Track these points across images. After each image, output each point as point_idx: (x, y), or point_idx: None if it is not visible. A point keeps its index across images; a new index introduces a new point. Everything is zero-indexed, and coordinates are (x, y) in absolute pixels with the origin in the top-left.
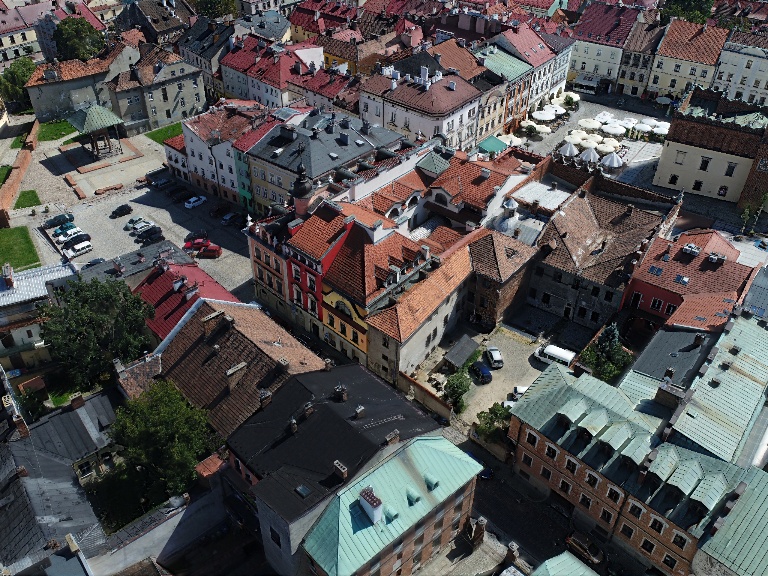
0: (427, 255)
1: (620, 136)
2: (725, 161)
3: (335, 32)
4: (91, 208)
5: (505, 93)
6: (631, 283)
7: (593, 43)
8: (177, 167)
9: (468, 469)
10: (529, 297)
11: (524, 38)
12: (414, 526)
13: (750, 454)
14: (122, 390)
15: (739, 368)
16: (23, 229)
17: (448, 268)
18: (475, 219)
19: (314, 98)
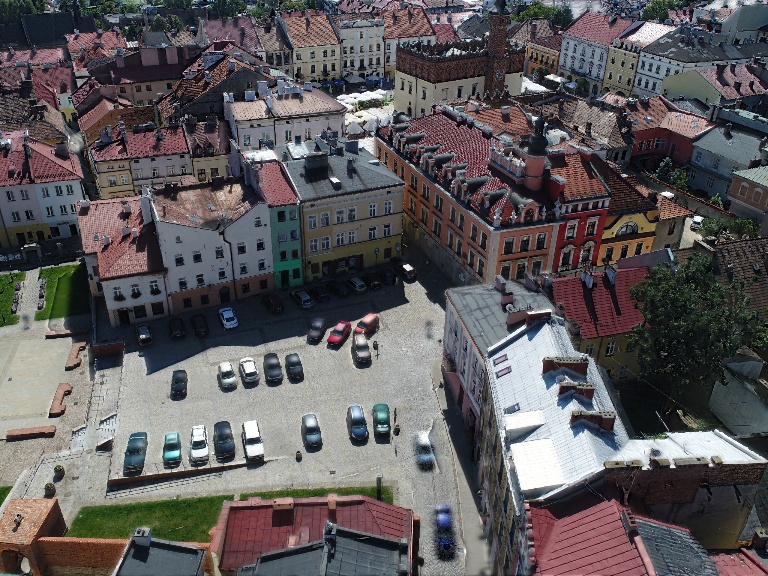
0: None
1: (348, 112)
2: (471, 85)
3: None
4: (125, 416)
5: None
6: None
7: None
8: (136, 305)
9: None
10: None
11: None
12: None
13: None
14: (736, 365)
15: None
16: (93, 512)
17: None
18: None
19: (153, 165)
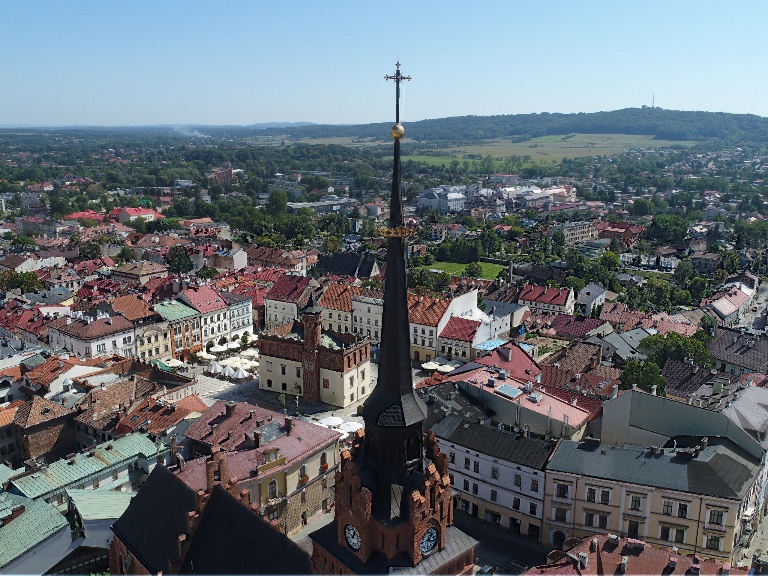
0: None
1: None
2: (294, 366)
3: (96, 299)
4: None
5: (167, 329)
6: (118, 427)
7: (278, 301)
8: None
9: None
10: (78, 450)
11: (203, 295)
12: None
13: None
14: None
15: (102, 456)
16: None
17: None
18: (43, 394)
19: (29, 336)
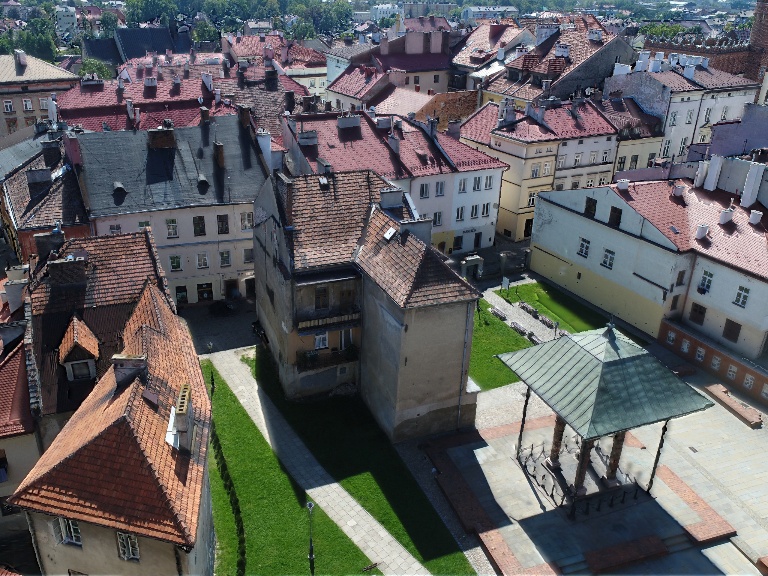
0: None
1: None
2: None
3: None
4: None
5: None
6: None
7: None
8: None
9: None
10: None
11: None
12: None
13: None
14: None
15: None
16: None
17: None
18: None
19: (579, 149)
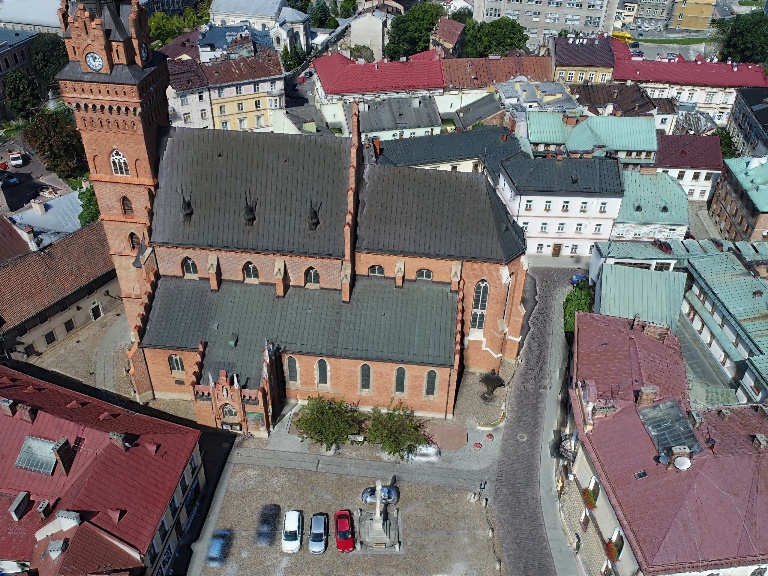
0: None
1: None
2: None
3: None
4: None
5: None
6: None
7: None
8: None
9: (763, 204)
10: None
11: None
12: None
13: (695, 341)
14: None
15: (767, 319)
16: None
17: None
18: None
19: None
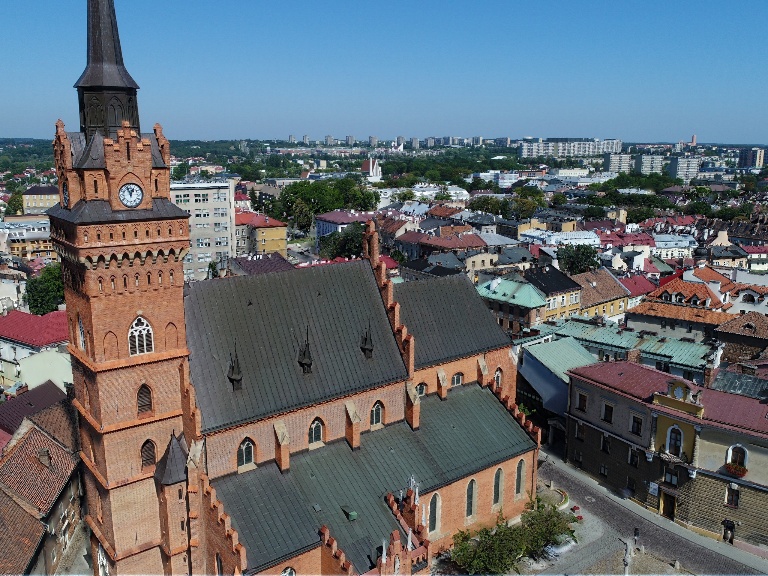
0: (707, 303)
1: None
2: None
3: None
4: None
5: None
6: None
7: None
8: None
9: None
10: None
11: None
12: (499, 306)
13: None
14: None
15: None
16: None
17: (705, 312)
18: None
19: None
